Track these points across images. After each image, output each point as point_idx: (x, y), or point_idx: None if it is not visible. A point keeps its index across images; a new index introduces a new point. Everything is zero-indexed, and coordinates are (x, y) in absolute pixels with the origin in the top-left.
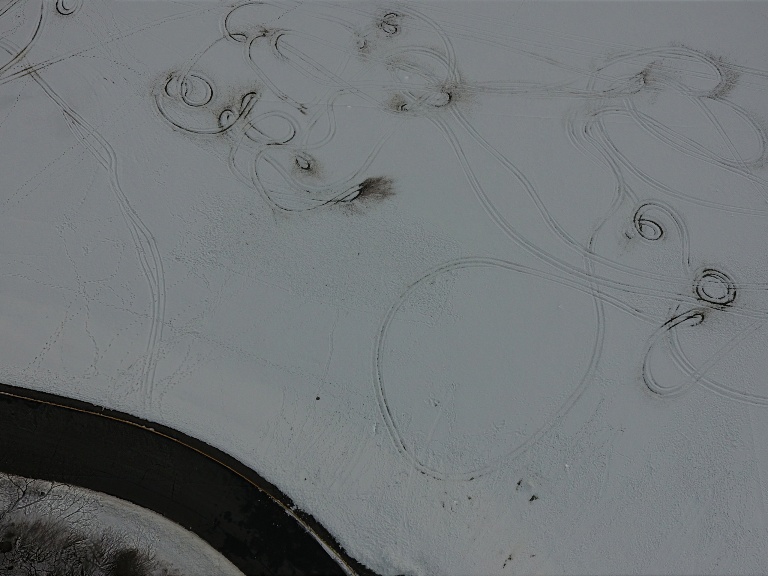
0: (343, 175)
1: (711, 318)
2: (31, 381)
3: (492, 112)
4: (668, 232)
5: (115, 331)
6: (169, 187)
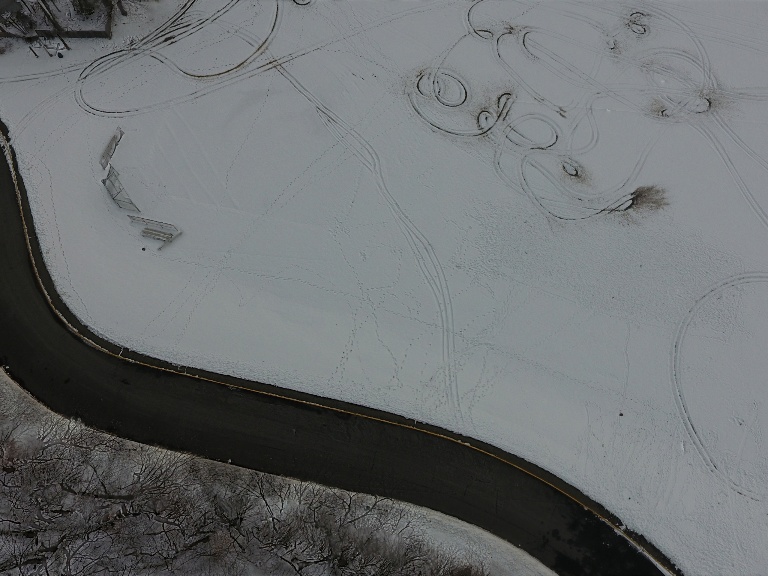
0: (613, 183)
1: None
2: (339, 392)
3: (755, 120)
4: None
5: (407, 341)
6: (438, 191)
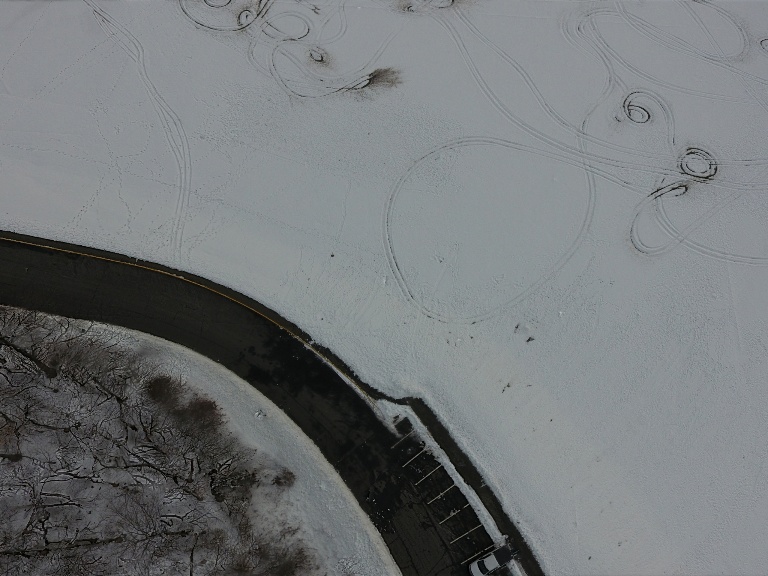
0: (354, 66)
1: (694, 189)
2: (71, 236)
3: (492, 13)
4: (655, 116)
5: (146, 198)
6: (193, 76)
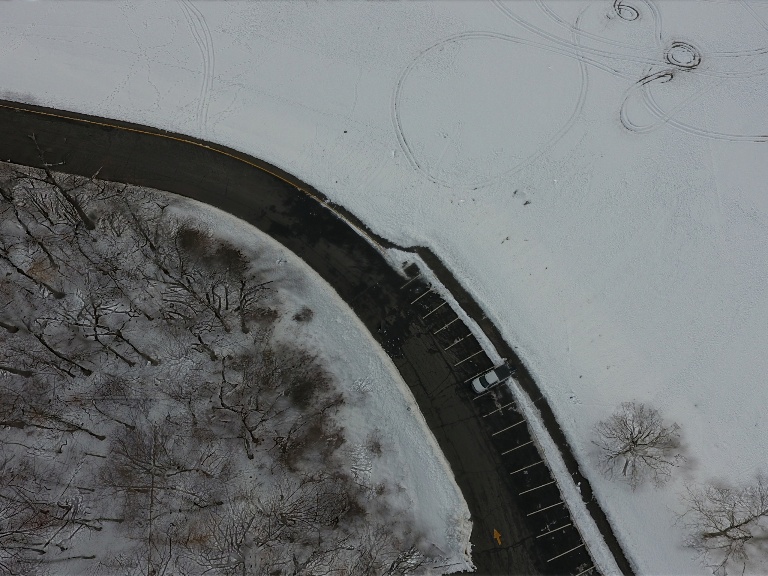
0: None
1: (679, 77)
2: (105, 111)
3: None
4: (643, 14)
5: (173, 82)
6: None
